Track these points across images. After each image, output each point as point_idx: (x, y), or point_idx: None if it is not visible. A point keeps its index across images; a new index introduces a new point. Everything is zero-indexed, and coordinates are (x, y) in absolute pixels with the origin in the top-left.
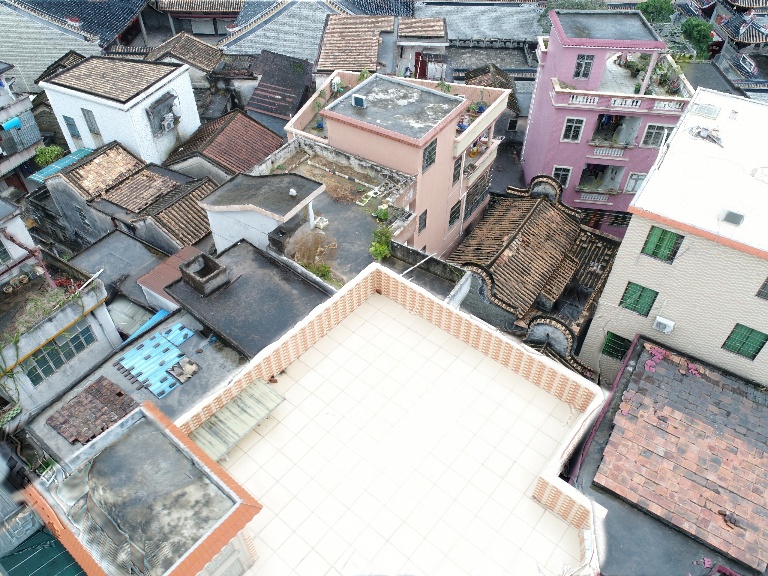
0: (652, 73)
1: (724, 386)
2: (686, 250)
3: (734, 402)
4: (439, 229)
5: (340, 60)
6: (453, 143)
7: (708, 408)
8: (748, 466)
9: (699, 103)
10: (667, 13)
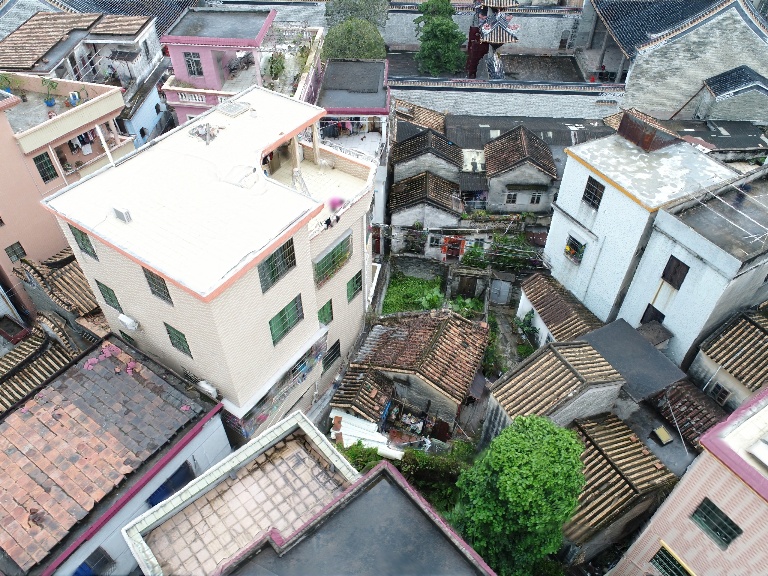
0: (264, 71)
1: (147, 385)
2: (95, 247)
3: (144, 401)
4: (44, 226)
5: (4, 57)
6: (14, 140)
7: (112, 406)
8: (101, 465)
9: (235, 101)
10: (445, 13)
